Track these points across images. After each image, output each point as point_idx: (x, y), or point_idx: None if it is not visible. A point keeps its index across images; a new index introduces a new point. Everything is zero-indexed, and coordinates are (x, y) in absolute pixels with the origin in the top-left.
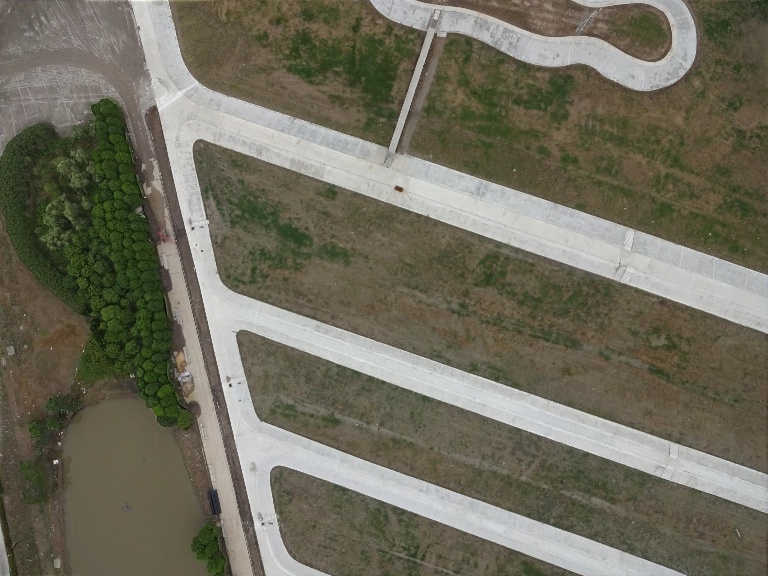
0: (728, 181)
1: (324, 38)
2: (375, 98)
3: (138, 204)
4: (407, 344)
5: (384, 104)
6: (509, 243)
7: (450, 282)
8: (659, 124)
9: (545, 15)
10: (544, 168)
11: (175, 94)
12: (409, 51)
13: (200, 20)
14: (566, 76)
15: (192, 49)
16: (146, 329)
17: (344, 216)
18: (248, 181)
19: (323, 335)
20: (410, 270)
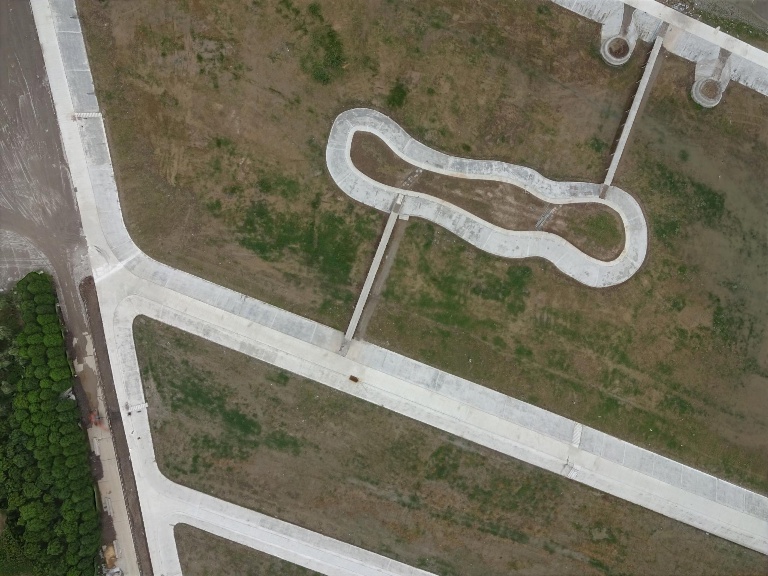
0: (669, 379)
1: (281, 212)
2: (333, 279)
3: (68, 388)
4: (355, 538)
5: (342, 286)
6: (462, 436)
7: (402, 474)
8: (609, 320)
9: (507, 208)
10: (499, 360)
11: (115, 265)
12: (370, 232)
13: (146, 183)
14: (524, 268)
15: (136, 214)
16: (72, 533)
17: (295, 403)
18: (193, 362)
19: (268, 530)
20: (362, 461)
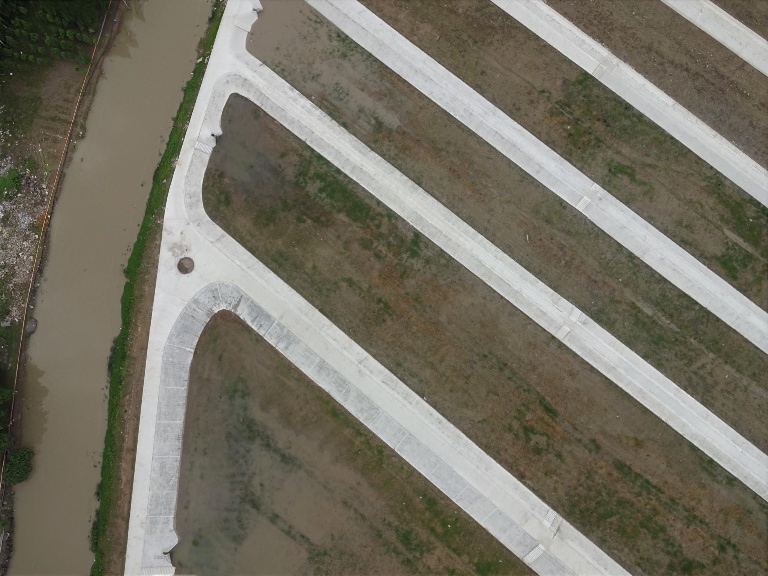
0: (411, 574)
1: None
2: None
3: None
4: None
5: None
6: None
7: None
8: None
9: None
10: None
11: None
12: None
13: None
14: None
15: None
16: None
17: None
18: None
19: None
20: None
